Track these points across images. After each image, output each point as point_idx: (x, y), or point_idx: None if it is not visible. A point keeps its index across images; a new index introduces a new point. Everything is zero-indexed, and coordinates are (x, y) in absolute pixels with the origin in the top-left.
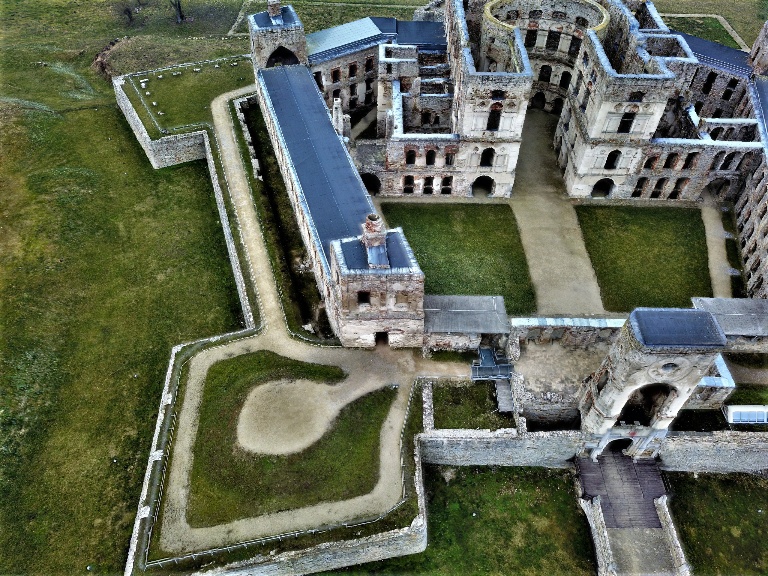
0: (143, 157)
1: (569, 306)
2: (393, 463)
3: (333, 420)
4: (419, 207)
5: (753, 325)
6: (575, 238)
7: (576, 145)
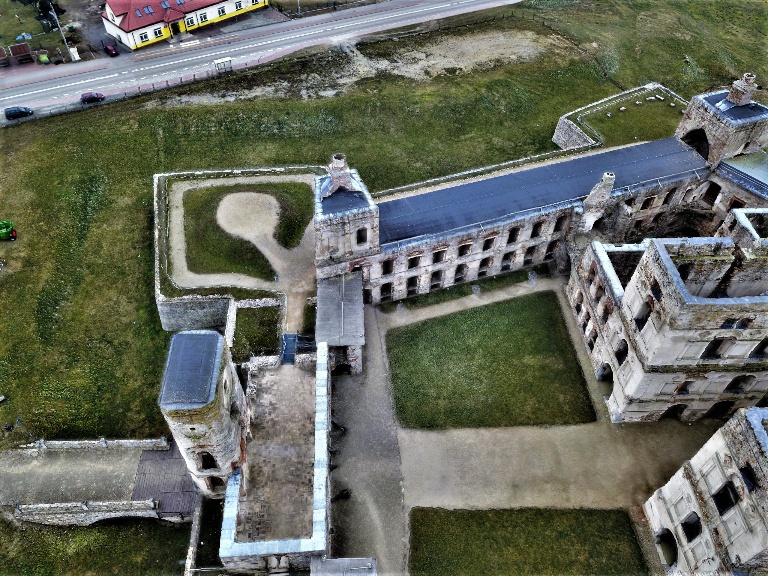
0: None
1: (414, 465)
2: (209, 281)
3: (240, 237)
4: (557, 324)
5: None
6: (548, 496)
7: None
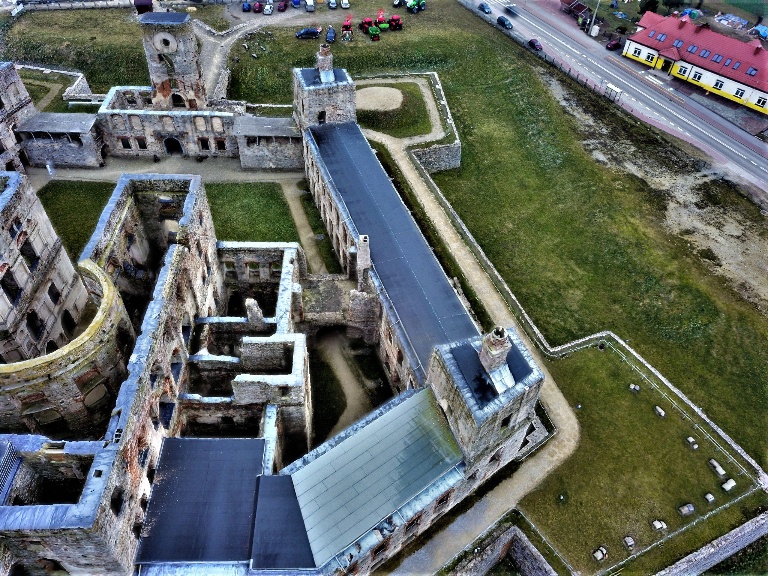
0: None
1: None
2: None
3: None
4: None
5: (61, 117)
6: None
7: (57, 285)
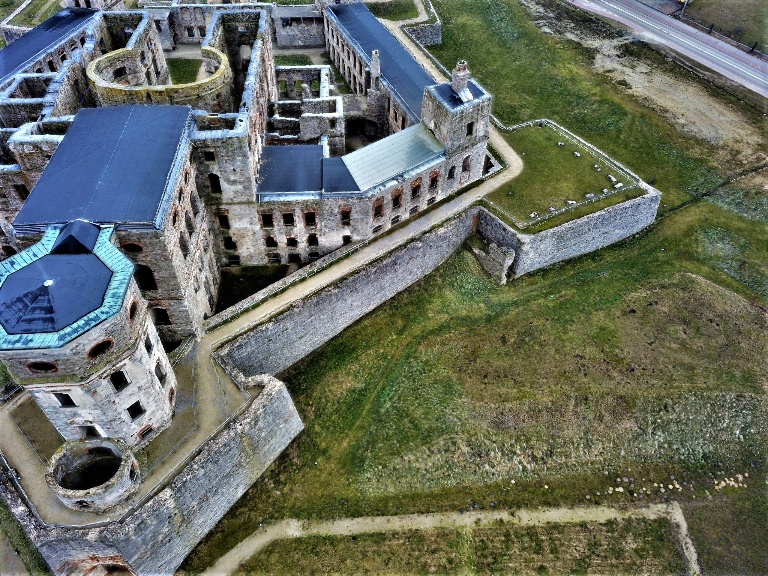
0: None
1: None
2: None
3: None
4: None
5: None
6: None
7: None
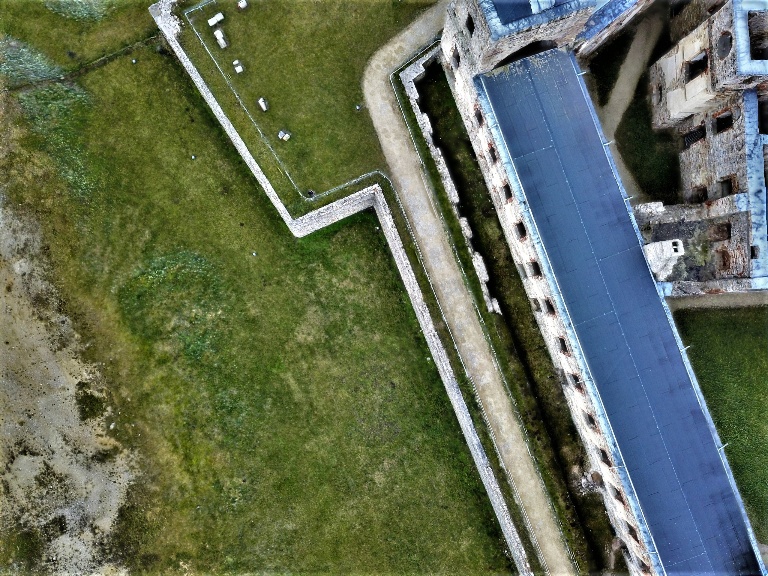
0: (267, 206)
1: None
2: None
3: None
4: (733, 319)
5: None
6: None
7: None
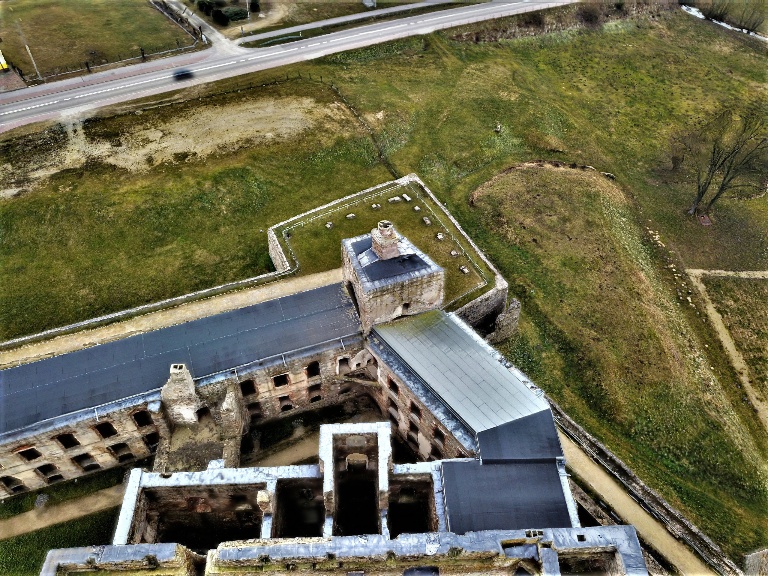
0: None
1: None
2: None
3: None
4: None
5: None
6: None
7: None
